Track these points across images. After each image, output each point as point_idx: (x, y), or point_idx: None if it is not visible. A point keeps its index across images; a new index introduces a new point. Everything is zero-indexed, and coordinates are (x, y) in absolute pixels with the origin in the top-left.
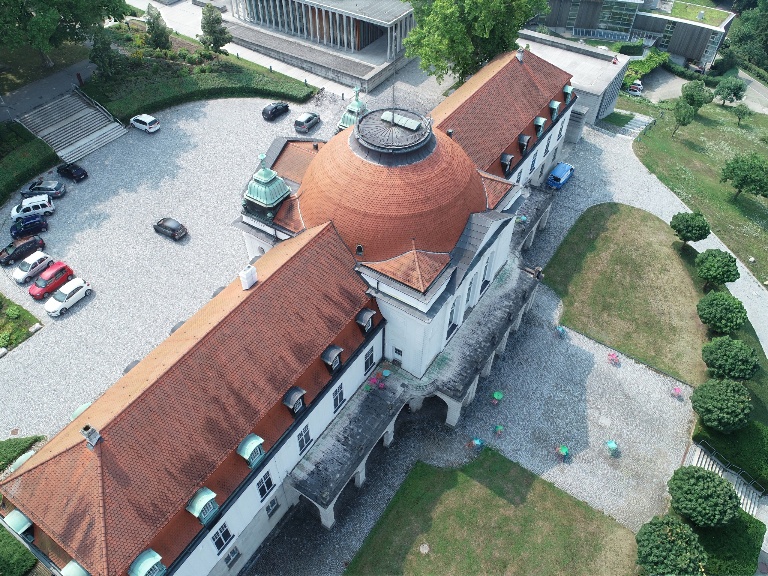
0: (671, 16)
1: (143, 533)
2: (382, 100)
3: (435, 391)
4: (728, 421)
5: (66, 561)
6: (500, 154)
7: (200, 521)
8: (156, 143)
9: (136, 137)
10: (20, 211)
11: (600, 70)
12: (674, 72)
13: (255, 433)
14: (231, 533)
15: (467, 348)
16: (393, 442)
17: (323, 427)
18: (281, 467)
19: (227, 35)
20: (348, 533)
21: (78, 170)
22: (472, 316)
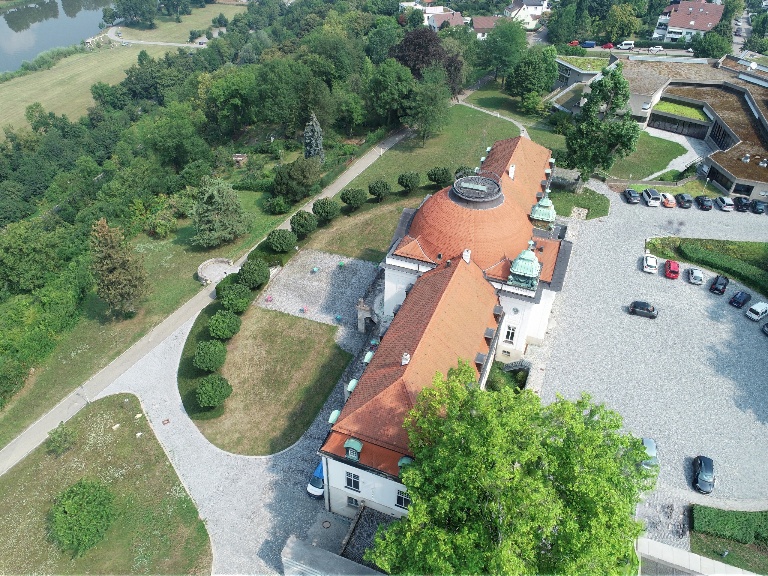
0: None
1: None
2: None
3: None
4: None
5: None
6: None
7: None
8: None
9: None
10: None
11: None
12: None
13: None
14: None
15: None
16: None
17: None
18: None
19: None
20: None
21: None
22: None
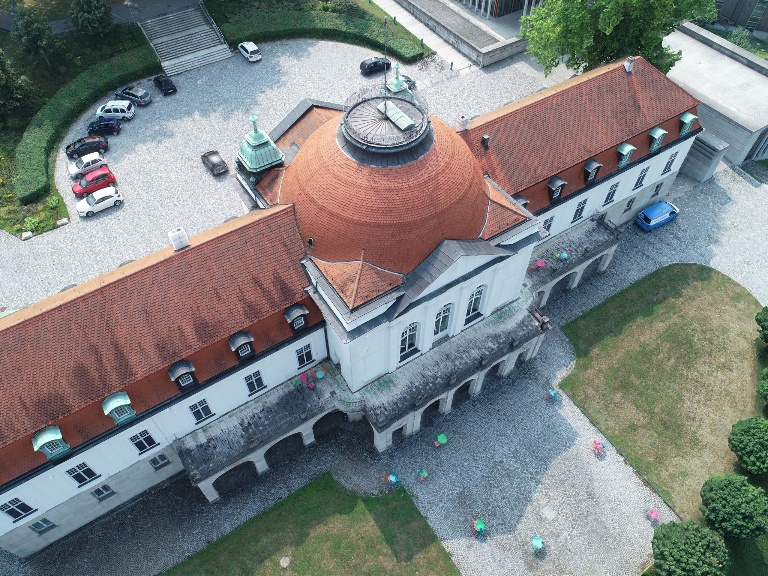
0: None
1: None
2: (492, 79)
3: (361, 411)
4: None
5: None
6: (548, 177)
7: None
8: (250, 73)
9: (237, 63)
10: (103, 111)
11: None
12: None
13: (129, 392)
14: (97, 472)
15: (419, 378)
16: (314, 444)
17: (233, 405)
18: (167, 430)
19: None
20: (226, 514)
21: (168, 84)
22: (445, 346)
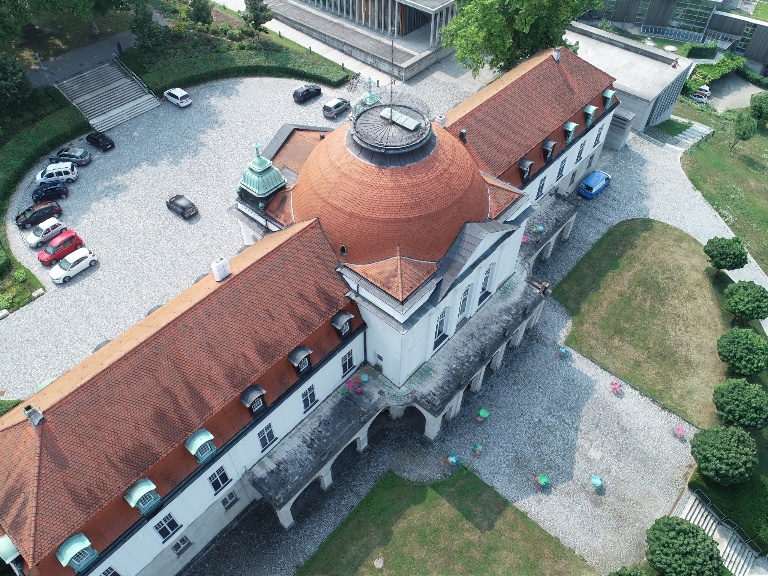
0: (752, 18)
1: (75, 517)
2: (418, 90)
3: (412, 402)
4: (726, 473)
5: (5, 533)
6: (518, 159)
7: (139, 510)
8: (185, 118)
9: (167, 110)
10: (44, 176)
11: (657, 73)
12: (749, 79)
13: (207, 428)
14: (179, 523)
15: (454, 361)
16: (367, 448)
17: (291, 426)
18: (238, 463)
19: (268, 13)
20: (305, 536)
21: (105, 140)
22: (466, 327)
